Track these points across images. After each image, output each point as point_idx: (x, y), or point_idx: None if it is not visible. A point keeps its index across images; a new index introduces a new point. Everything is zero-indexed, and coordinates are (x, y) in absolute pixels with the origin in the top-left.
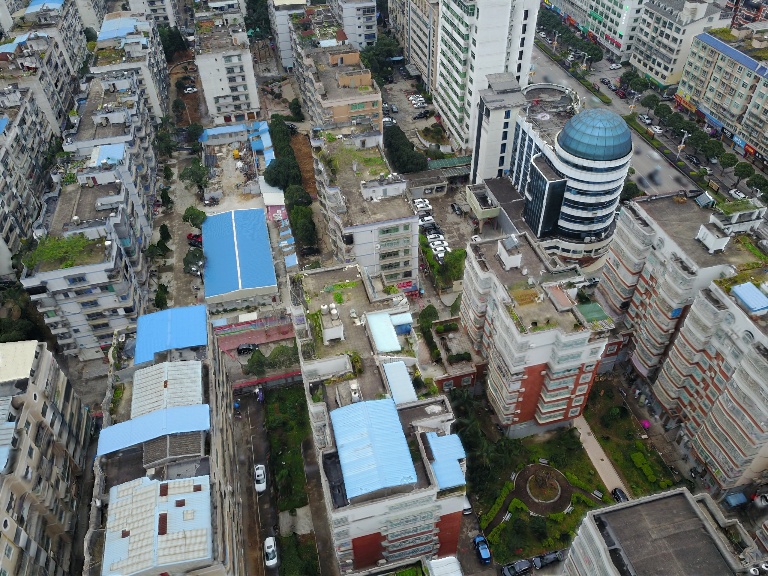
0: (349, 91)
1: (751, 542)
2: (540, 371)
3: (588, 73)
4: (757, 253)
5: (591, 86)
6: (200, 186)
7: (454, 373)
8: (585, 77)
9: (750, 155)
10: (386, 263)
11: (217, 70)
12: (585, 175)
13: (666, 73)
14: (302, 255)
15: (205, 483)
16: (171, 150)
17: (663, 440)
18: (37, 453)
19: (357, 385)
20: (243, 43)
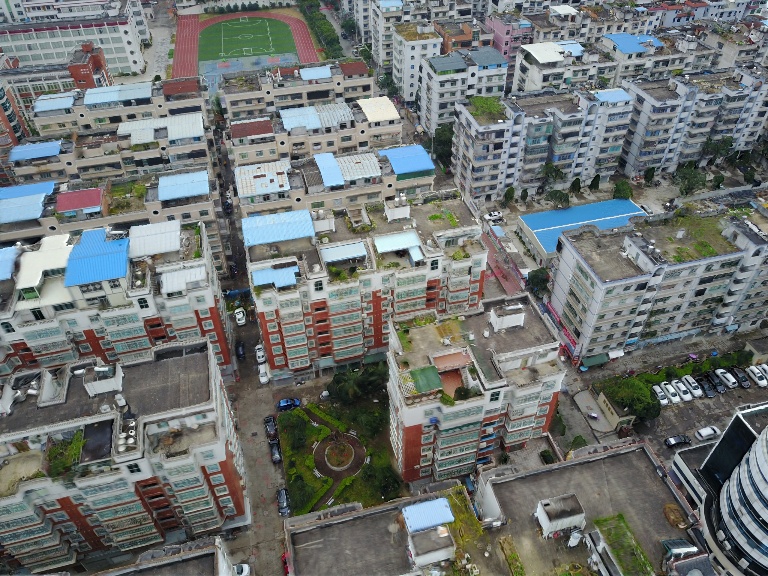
0: None
1: (168, 458)
2: None
3: None
4: None
5: None
6: (687, 193)
7: None
8: None
9: None
10: (569, 301)
11: None
12: (760, 447)
13: None
14: None
15: (285, 188)
16: None
17: None
18: (334, 149)
19: None
20: None
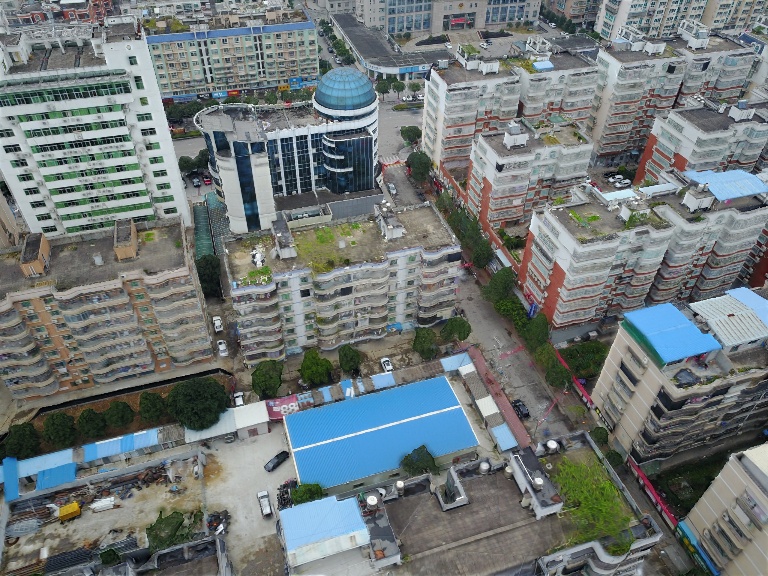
0: (151, 250)
1: None
2: None
3: None
4: None
5: None
6: None
7: None
8: None
9: None
10: None
11: None
12: None
13: None
14: None
15: None
16: None
17: None
18: None
19: None
20: None
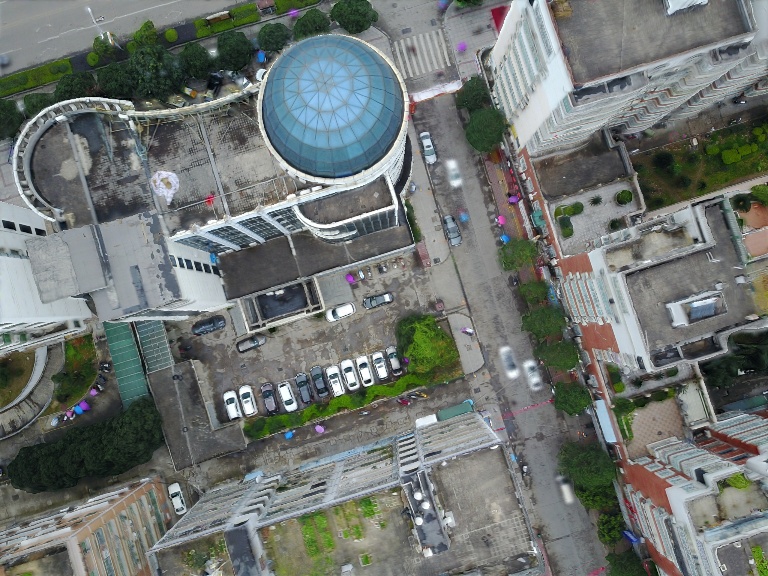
0: None
1: None
2: None
3: None
4: None
5: None
6: None
7: (692, 369)
8: None
9: None
10: None
11: None
12: None
13: None
14: None
15: None
16: None
17: (696, 122)
18: None
19: None
20: None
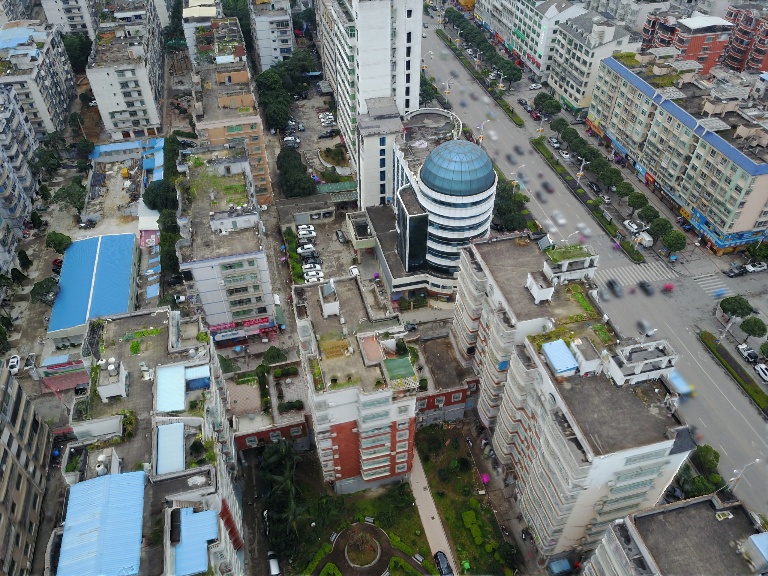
0: (228, 112)
1: None
2: (351, 428)
3: (505, 93)
4: (584, 304)
5: (506, 107)
6: None
7: (281, 423)
8: (502, 97)
9: (651, 183)
10: (235, 299)
11: (110, 84)
12: (444, 210)
13: (578, 96)
14: (168, 285)
15: None
16: (60, 167)
17: (501, 496)
18: None
19: (109, 454)
20: (139, 57)
